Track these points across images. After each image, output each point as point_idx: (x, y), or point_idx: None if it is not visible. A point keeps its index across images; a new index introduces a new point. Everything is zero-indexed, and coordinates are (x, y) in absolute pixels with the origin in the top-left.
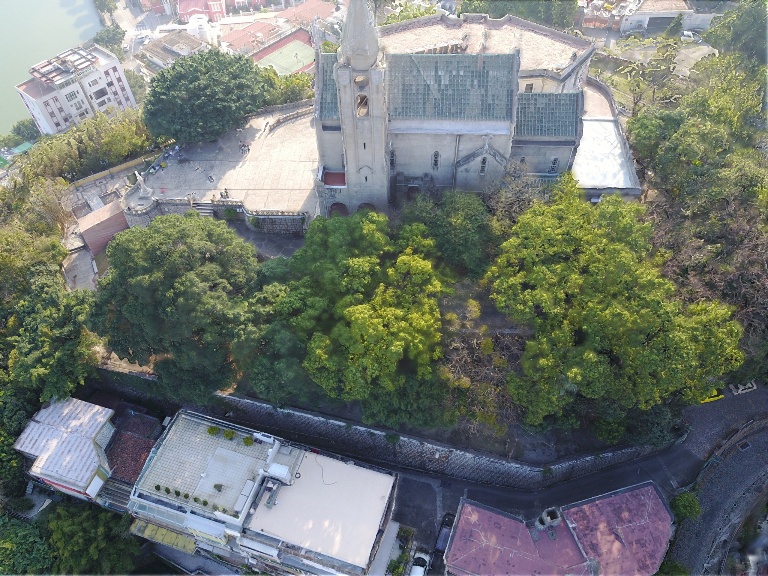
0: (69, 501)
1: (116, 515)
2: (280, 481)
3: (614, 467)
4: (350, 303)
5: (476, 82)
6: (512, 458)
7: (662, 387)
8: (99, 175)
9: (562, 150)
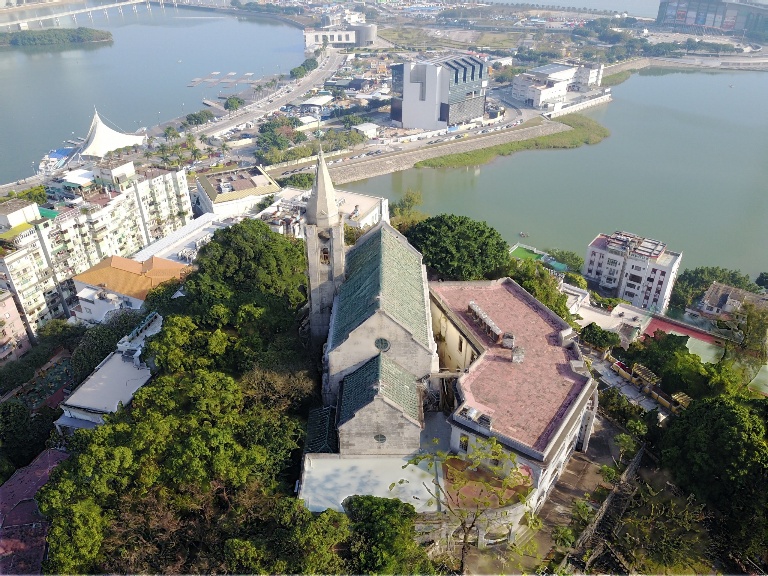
0: None
1: None
2: None
3: None
4: None
5: None
6: None
7: None
8: None
9: None
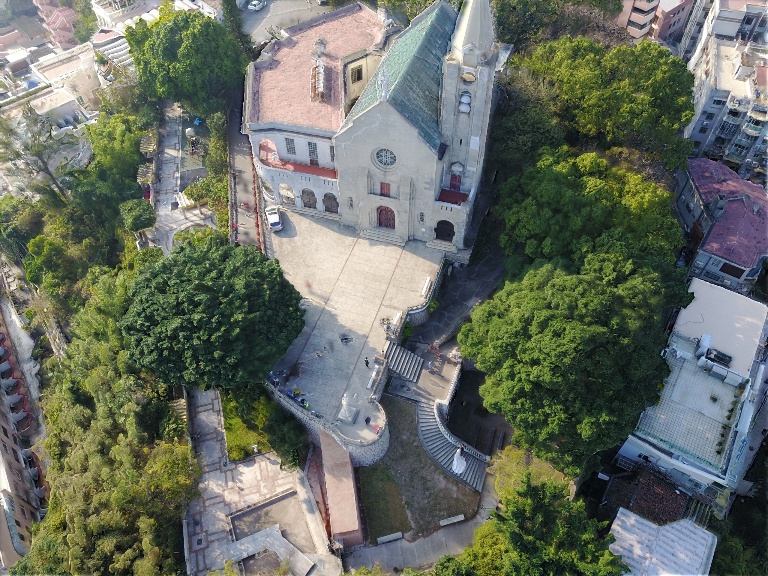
0: None
1: None
2: None
3: None
4: None
5: None
6: None
7: None
8: None
9: None
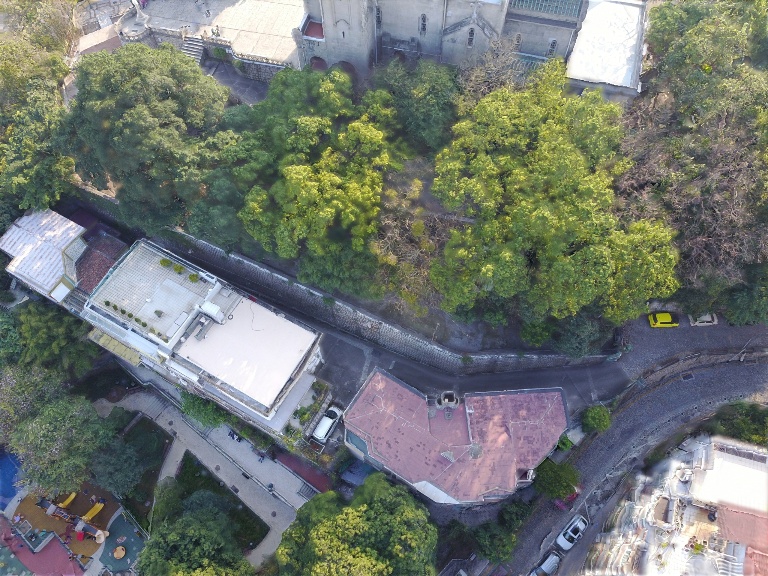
0: (45, 302)
1: (79, 321)
2: (212, 318)
3: (541, 370)
4: (292, 162)
5: None
6: (437, 341)
7: (573, 299)
8: None
9: (561, 32)
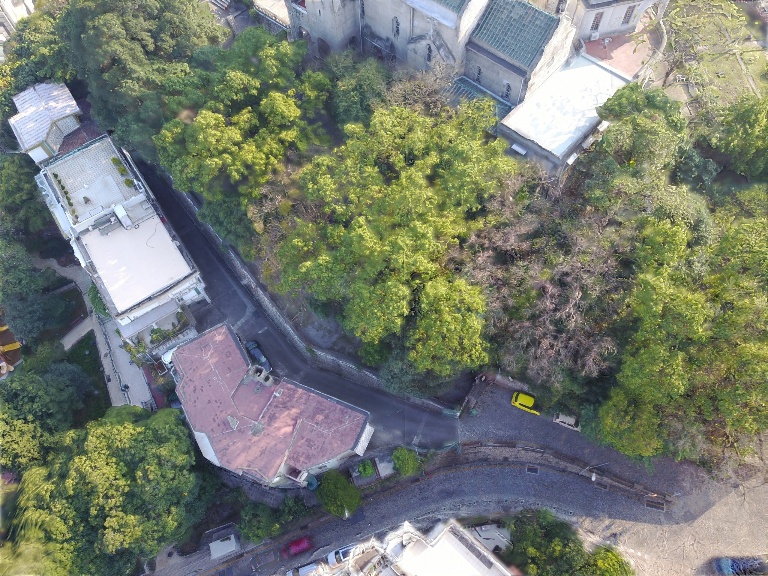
0: None
1: None
2: (119, 221)
3: (384, 394)
4: (211, 108)
5: None
6: (294, 323)
7: None
8: None
9: (514, 77)
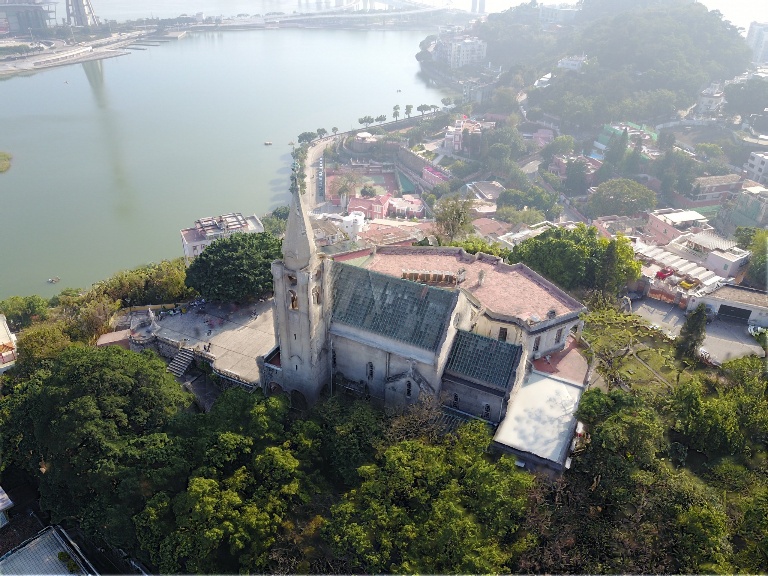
0: None
1: None
2: None
3: None
4: (202, 474)
5: (416, 309)
6: None
7: None
8: (154, 307)
9: (493, 398)
